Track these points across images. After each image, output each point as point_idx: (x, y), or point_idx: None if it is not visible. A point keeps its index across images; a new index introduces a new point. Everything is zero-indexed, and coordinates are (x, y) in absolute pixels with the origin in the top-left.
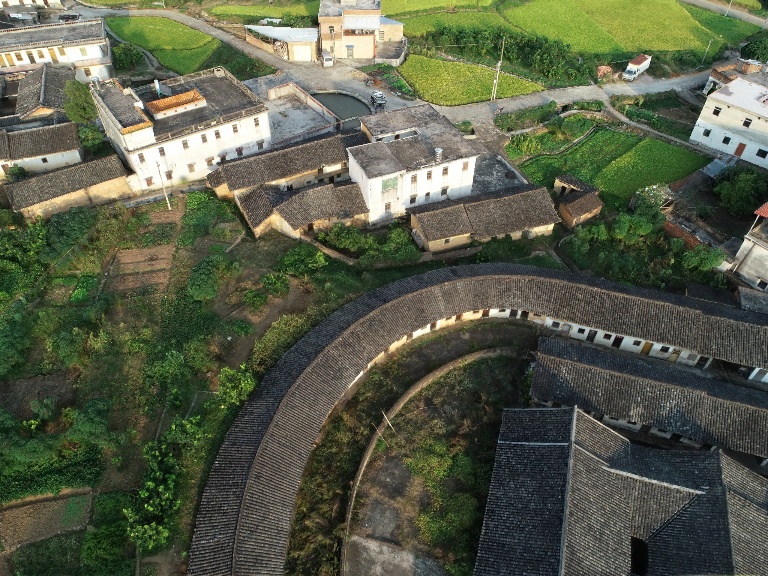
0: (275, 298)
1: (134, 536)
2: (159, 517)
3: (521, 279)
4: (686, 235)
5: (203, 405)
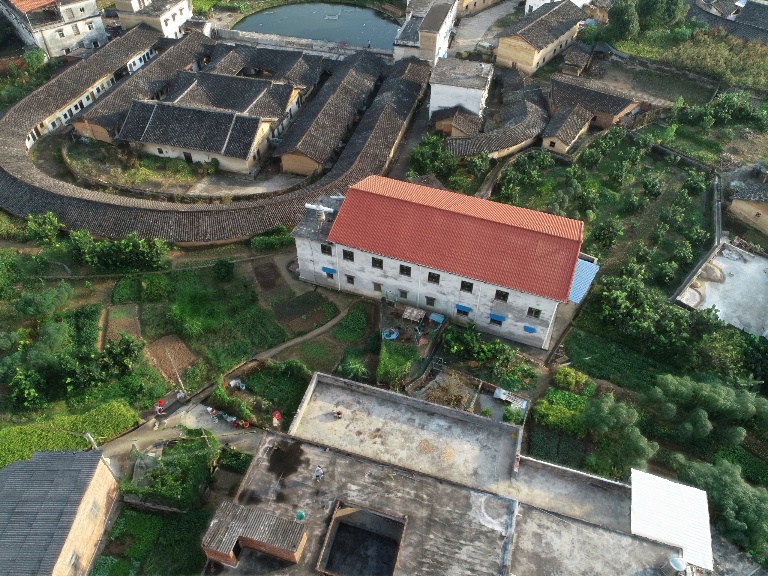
0: None
1: (159, 255)
2: None
3: (10, 114)
4: (7, 63)
5: (51, 255)
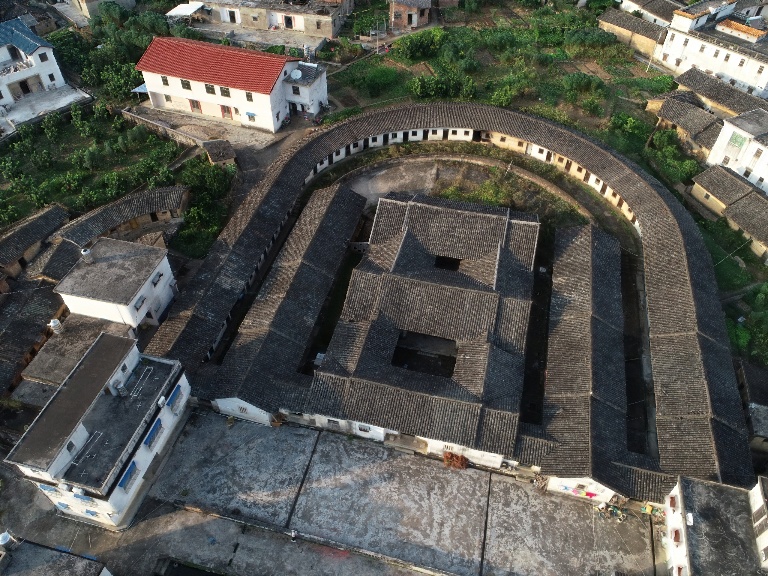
0: (582, 112)
1: None
2: (425, 89)
3: (671, 218)
4: None
5: None
